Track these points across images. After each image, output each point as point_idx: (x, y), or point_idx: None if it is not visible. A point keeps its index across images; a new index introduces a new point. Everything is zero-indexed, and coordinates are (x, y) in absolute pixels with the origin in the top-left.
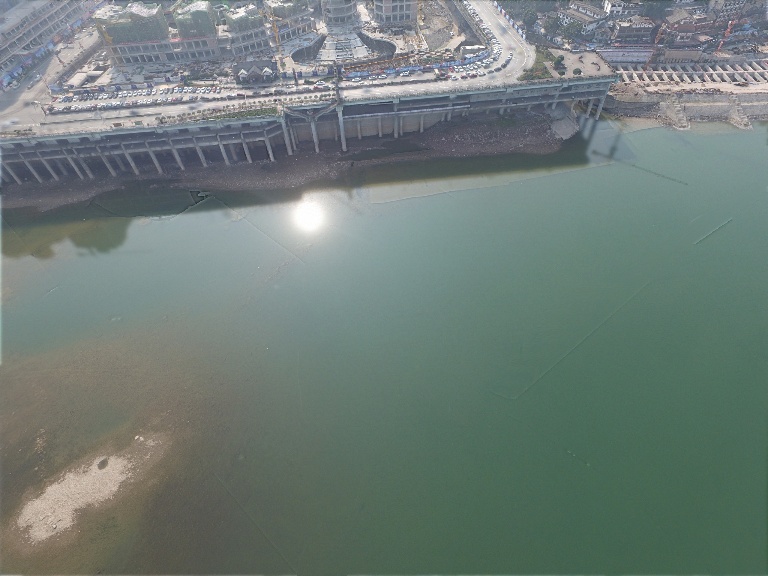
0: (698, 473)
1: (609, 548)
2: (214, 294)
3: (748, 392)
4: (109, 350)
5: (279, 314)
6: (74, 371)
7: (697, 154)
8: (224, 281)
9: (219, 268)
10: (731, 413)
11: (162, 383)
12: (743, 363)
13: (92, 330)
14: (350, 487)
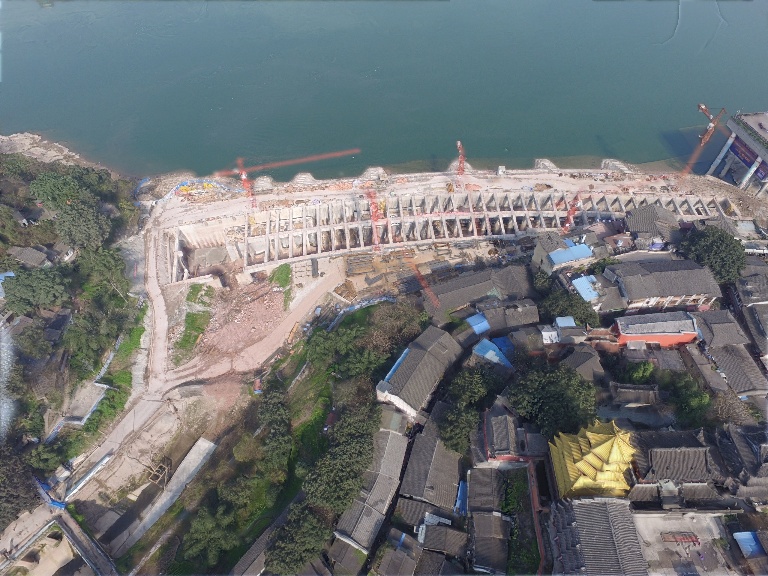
0: (625, 24)
1: (663, 7)
2: None
3: (598, 38)
4: None
5: None
6: None
7: (601, 135)
8: None
9: None
10: (609, 33)
11: None
12: (599, 43)
13: None
14: (763, 25)
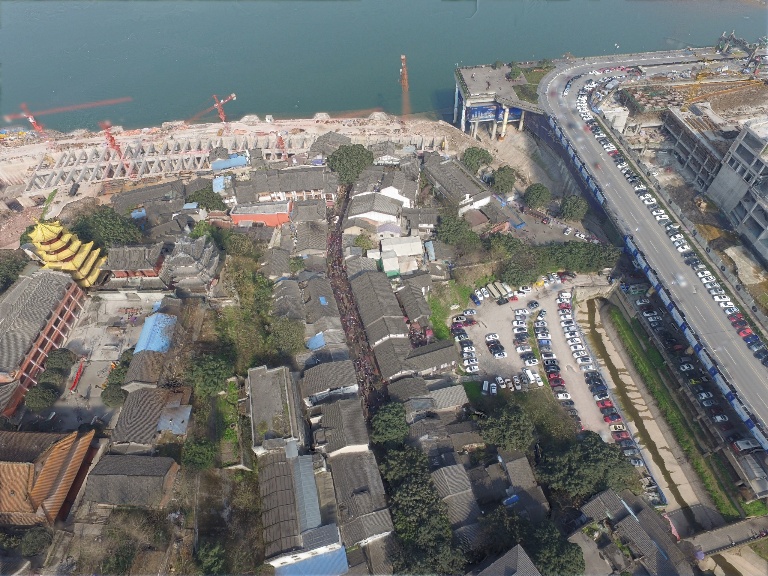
0: (464, 4)
1: None
2: (704, 25)
3: None
4: (733, 9)
5: (659, 21)
6: (740, 4)
7: (384, 93)
8: (704, 29)
9: (714, 34)
10: None
11: (693, 3)
12: None
13: (753, 14)
14: None
